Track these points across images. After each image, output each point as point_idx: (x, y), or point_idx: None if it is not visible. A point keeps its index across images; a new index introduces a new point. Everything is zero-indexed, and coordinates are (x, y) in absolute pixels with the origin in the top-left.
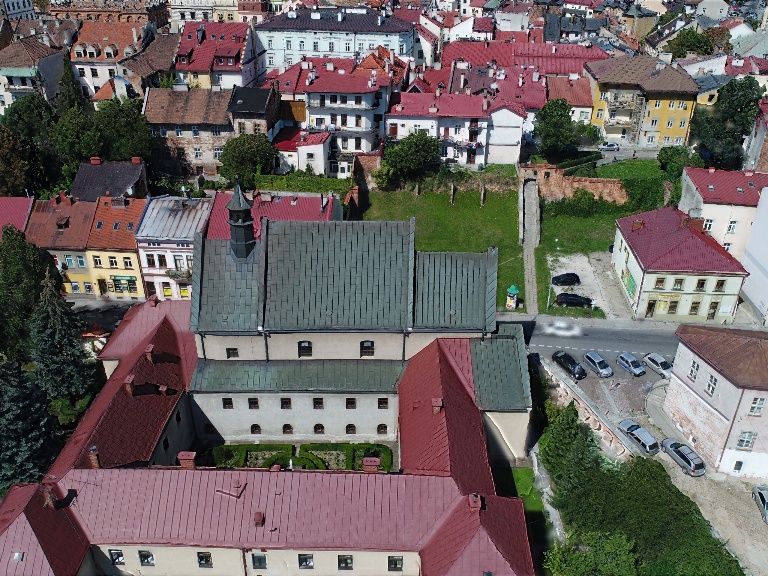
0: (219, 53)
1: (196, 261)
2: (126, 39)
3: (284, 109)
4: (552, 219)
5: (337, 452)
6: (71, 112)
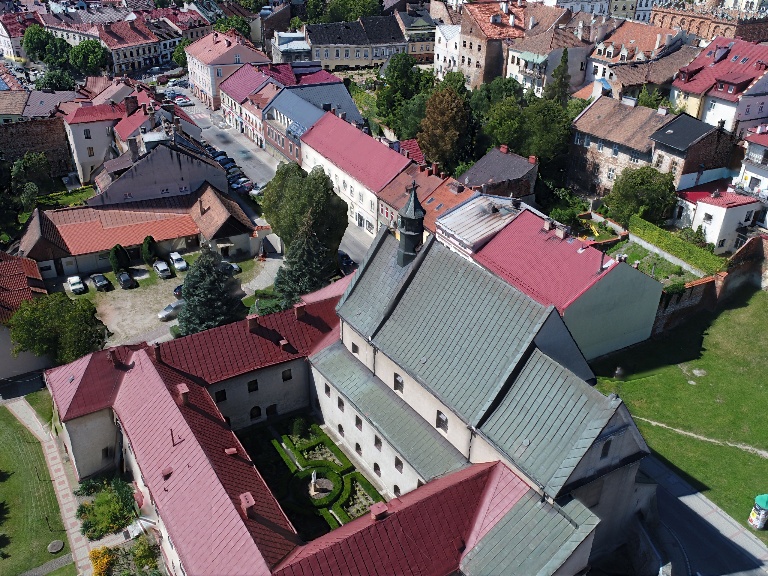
0: (724, 77)
1: (370, 250)
2: (650, 45)
3: (735, 156)
4: None
5: (373, 502)
6: (509, 99)
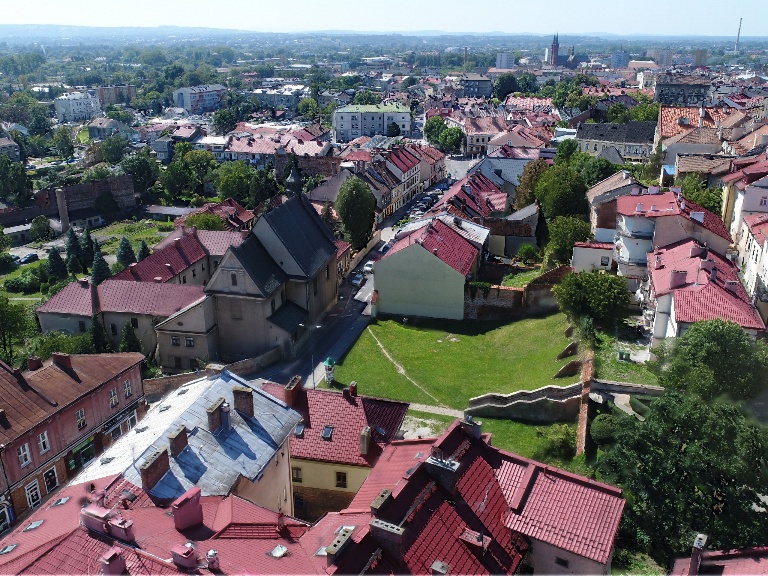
0: (751, 169)
1: None
2: None
3: None
4: (532, 433)
5: None
6: None
